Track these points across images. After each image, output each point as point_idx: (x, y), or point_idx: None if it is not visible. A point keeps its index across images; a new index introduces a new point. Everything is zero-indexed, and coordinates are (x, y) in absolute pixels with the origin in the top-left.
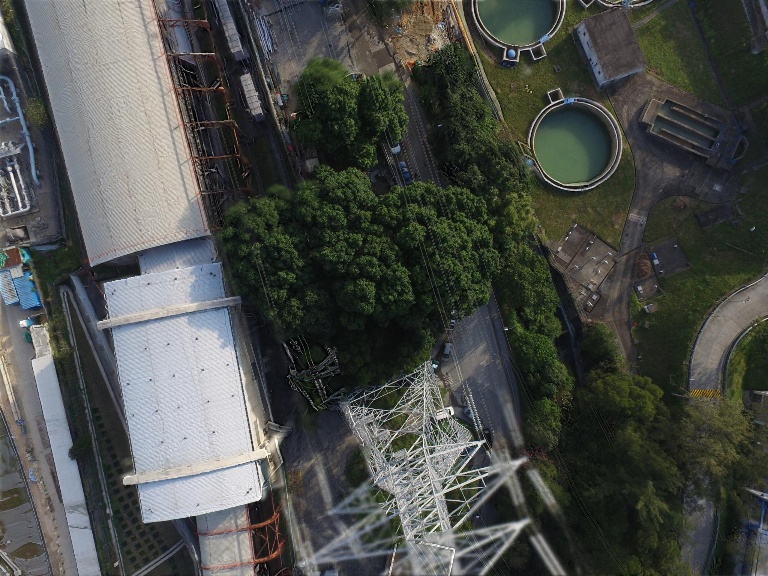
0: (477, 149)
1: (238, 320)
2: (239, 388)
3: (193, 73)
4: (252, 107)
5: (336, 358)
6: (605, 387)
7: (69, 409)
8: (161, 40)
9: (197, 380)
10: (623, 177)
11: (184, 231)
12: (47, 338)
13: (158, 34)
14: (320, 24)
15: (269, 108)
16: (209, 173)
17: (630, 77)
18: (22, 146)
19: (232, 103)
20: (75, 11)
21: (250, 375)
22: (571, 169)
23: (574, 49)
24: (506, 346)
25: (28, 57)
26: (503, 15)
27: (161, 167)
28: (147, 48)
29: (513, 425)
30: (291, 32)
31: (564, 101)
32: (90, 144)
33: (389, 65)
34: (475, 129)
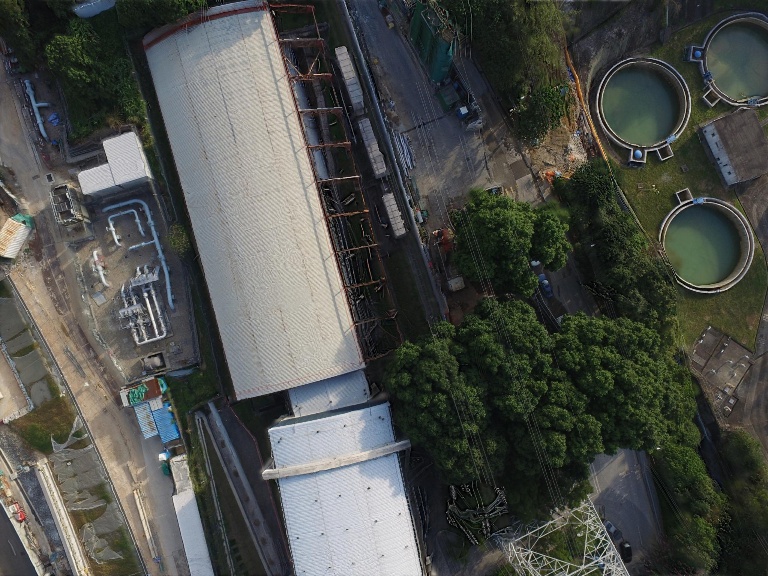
0: (637, 273)
1: (408, 465)
2: (412, 538)
3: (328, 190)
4: (396, 228)
5: (505, 498)
6: (763, 506)
7: (211, 546)
8: (311, 168)
9: (371, 533)
10: (756, 277)
11: (340, 365)
12: (188, 472)
13: (308, 162)
14: (458, 138)
15: (411, 227)
16: (360, 301)
17: (761, 177)
18: (158, 271)
19: (367, 218)
20: (224, 141)
21: (418, 520)
22: (702, 269)
23: (700, 148)
24: (649, 458)
25: (166, 182)
26: (625, 114)
27: (315, 300)
28: (298, 177)
29: (657, 539)
30: (429, 147)
31: (693, 201)
32: (234, 272)
33: (526, 176)
34: (630, 249)
